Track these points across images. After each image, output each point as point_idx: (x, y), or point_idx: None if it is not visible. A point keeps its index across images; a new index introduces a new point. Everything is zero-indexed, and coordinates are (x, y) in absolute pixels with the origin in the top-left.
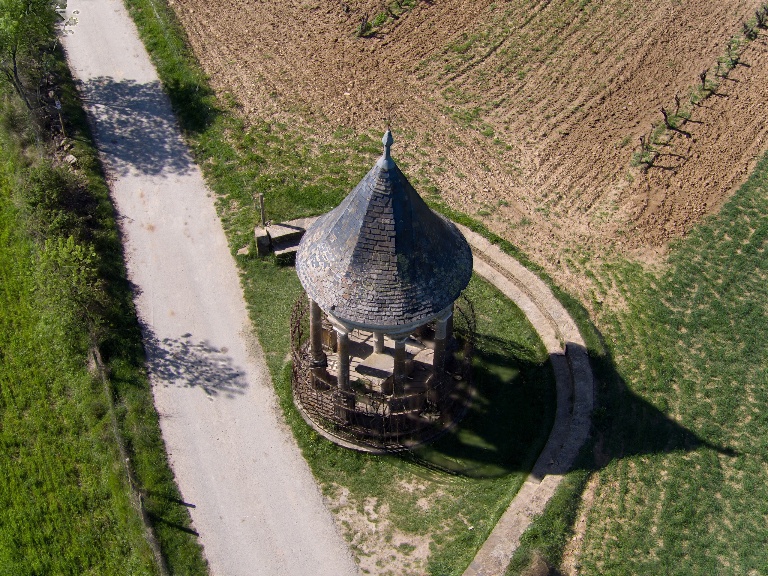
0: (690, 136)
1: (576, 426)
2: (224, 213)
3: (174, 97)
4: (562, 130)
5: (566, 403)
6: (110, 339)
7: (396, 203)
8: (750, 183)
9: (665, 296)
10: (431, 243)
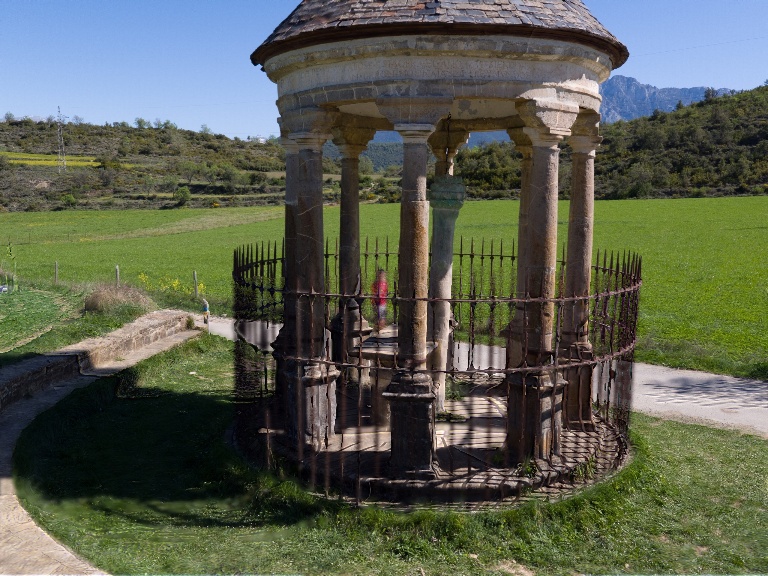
0: None
1: None
2: None
3: None
4: None
5: None
6: None
7: None
8: None
9: None
10: None
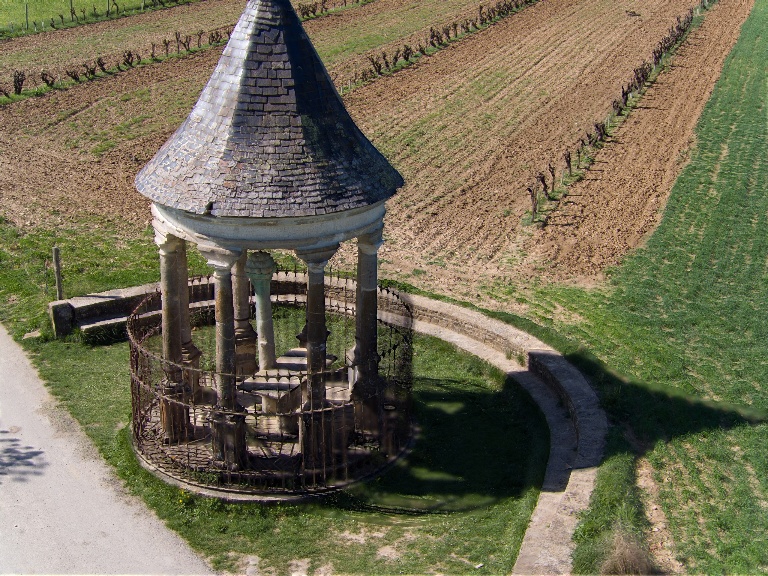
0: (577, 204)
1: (586, 418)
2: None
3: None
4: (428, 211)
5: (555, 410)
6: None
7: (289, 40)
8: (665, 226)
9: (627, 307)
10: (344, 113)
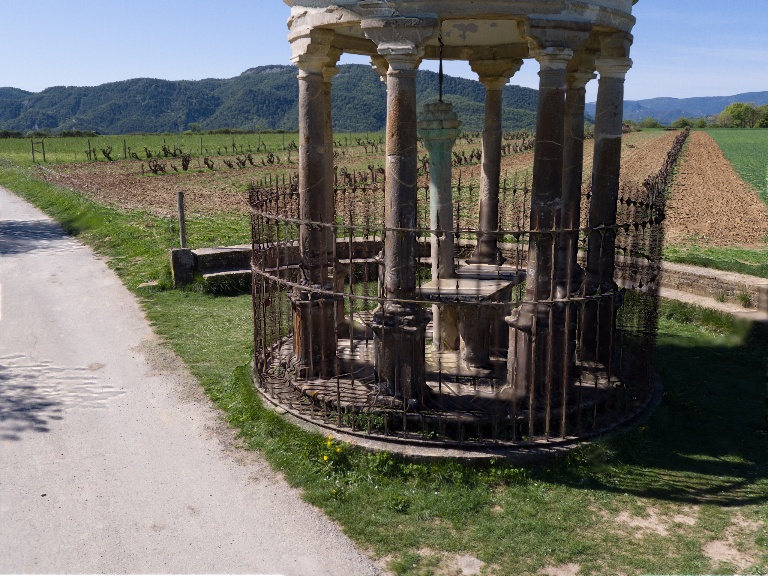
0: None
1: None
2: (120, 266)
3: (66, 220)
4: None
5: None
6: None
7: None
8: None
9: None
10: None
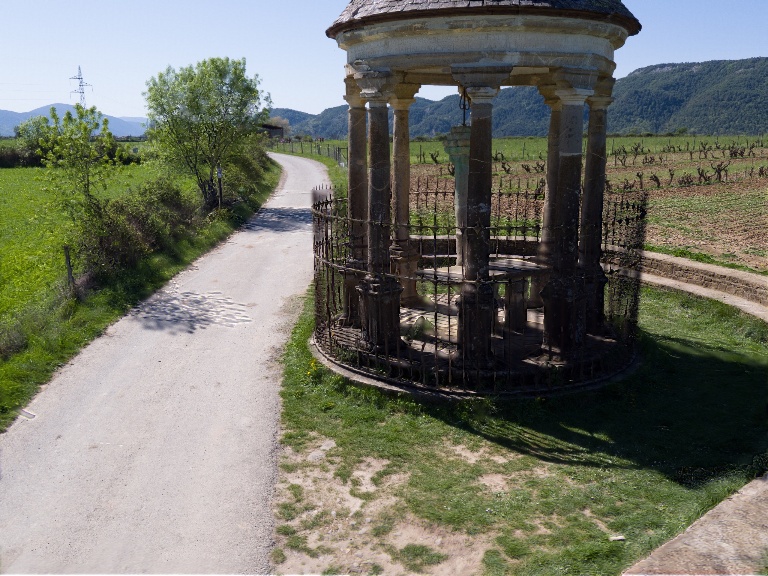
0: None
1: None
2: None
3: None
4: None
5: None
6: (115, 275)
7: None
8: None
9: None
10: None
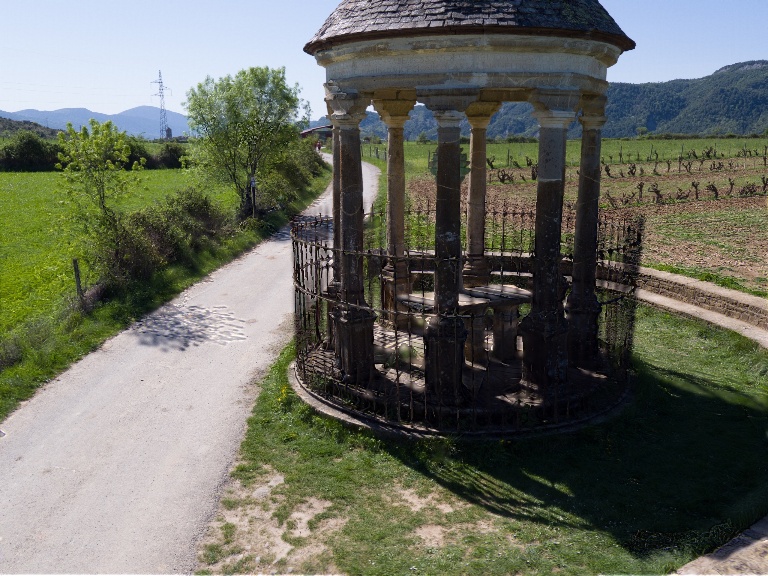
0: None
1: None
2: None
3: None
4: None
5: None
6: (127, 287)
7: None
8: None
9: None
10: None
